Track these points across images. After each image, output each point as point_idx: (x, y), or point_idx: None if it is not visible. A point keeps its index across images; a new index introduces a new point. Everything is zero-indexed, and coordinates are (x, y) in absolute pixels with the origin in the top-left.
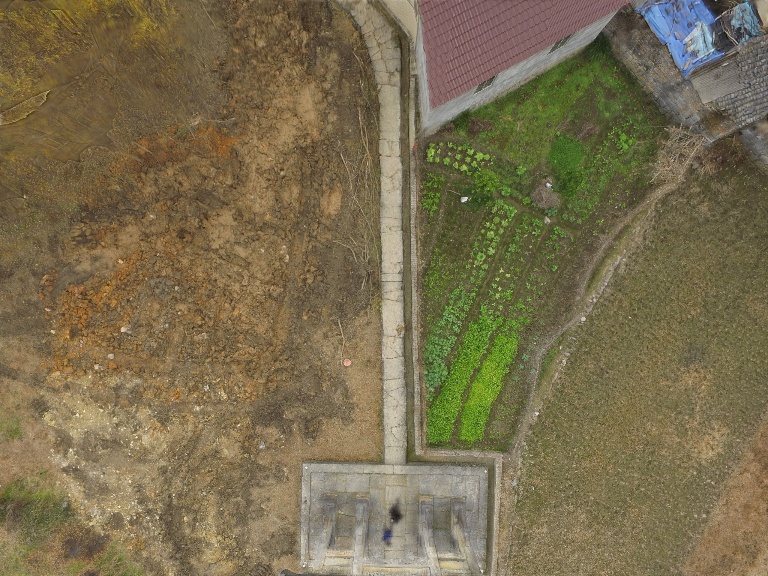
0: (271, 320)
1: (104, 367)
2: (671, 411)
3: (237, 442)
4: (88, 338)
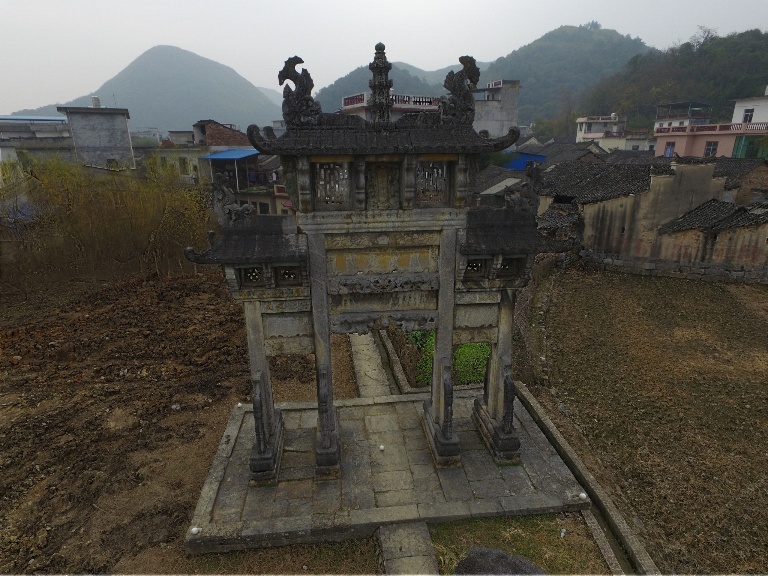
0: (228, 329)
1: (1, 360)
2: (693, 351)
3: (136, 412)
4: (2, 351)
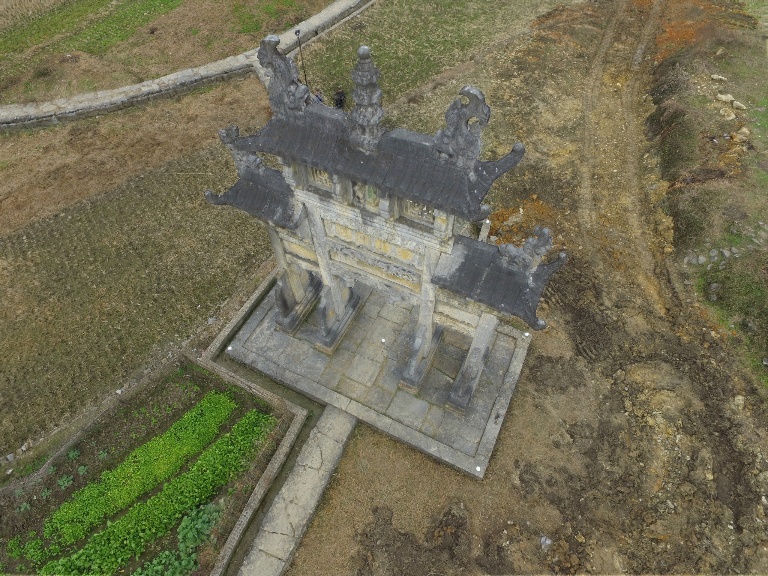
0: None
1: None
2: None
3: (594, 573)
4: None
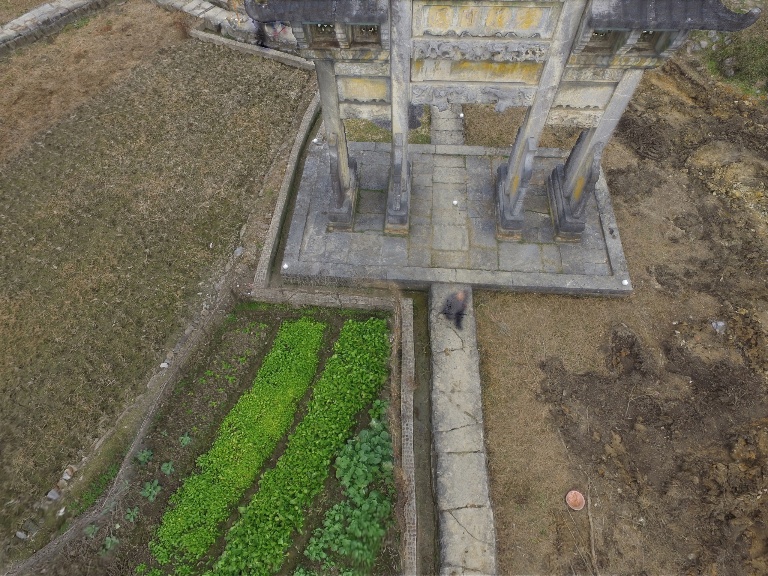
0: None
1: None
2: None
3: None
4: None
